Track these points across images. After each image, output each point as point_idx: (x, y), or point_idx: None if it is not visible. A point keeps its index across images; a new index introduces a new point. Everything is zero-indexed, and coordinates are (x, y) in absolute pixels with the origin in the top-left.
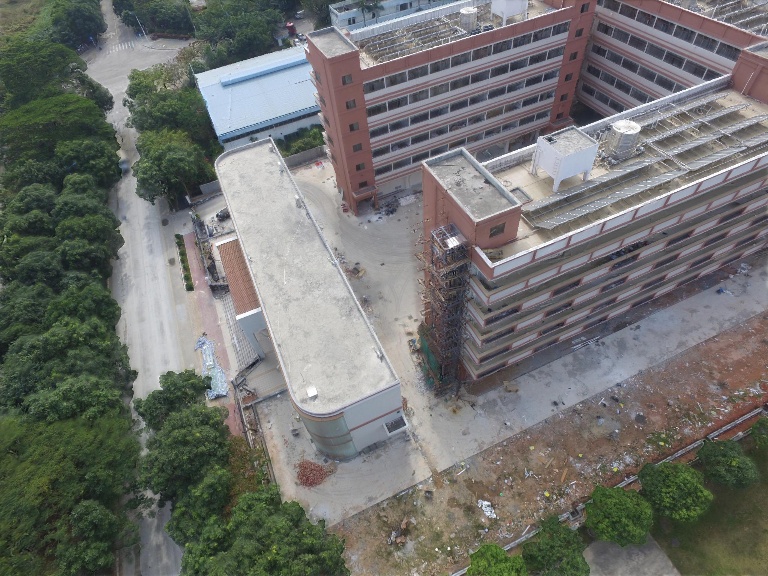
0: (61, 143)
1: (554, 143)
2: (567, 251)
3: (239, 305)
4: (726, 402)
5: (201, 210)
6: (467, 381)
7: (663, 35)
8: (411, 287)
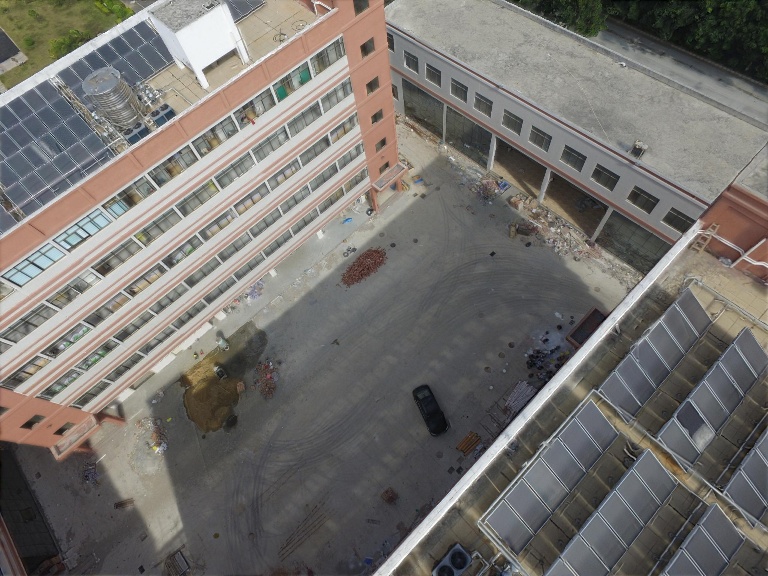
0: None
1: (206, 3)
2: None
3: None
4: None
5: None
6: None
7: None
8: (438, 232)
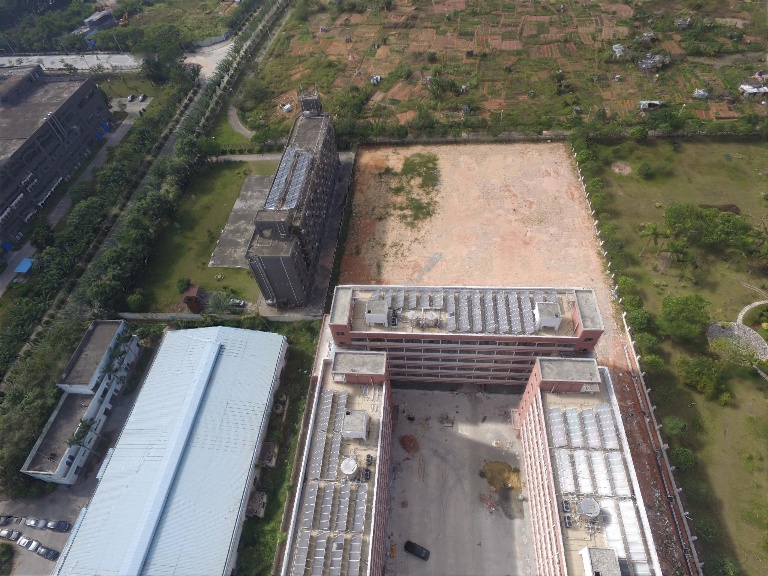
0: None
1: (602, 575)
2: None
3: None
4: (662, 516)
5: None
6: None
7: (433, 345)
8: None
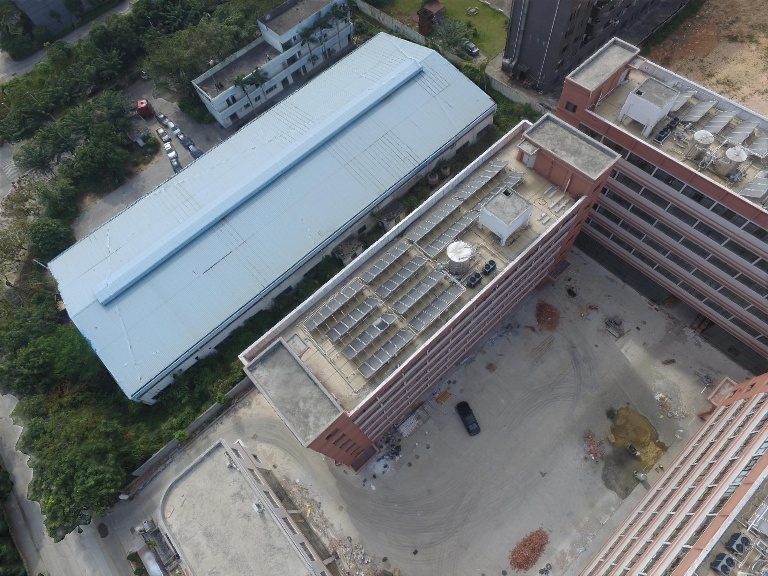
0: None
1: None
2: None
3: None
4: None
5: (146, 500)
6: None
7: (695, 205)
8: None
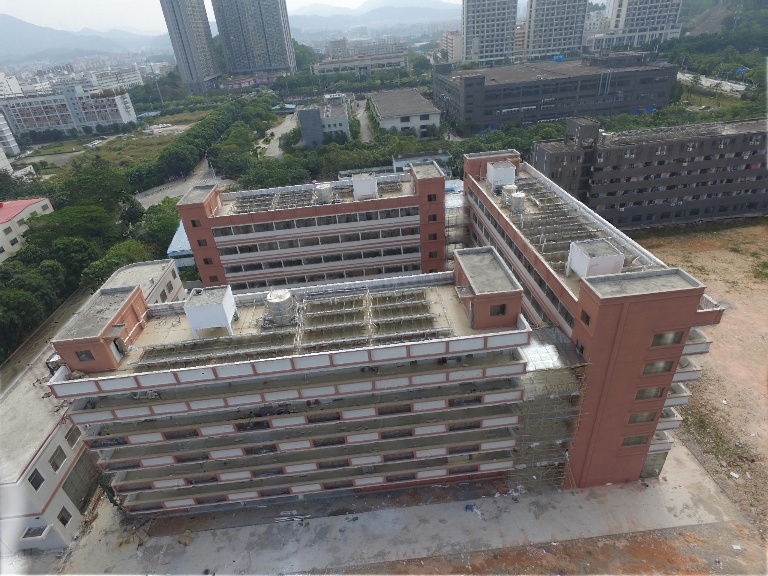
0: (62, 237)
1: (197, 295)
2: (161, 394)
3: None
4: None
5: None
6: (157, 517)
7: (494, 231)
8: None
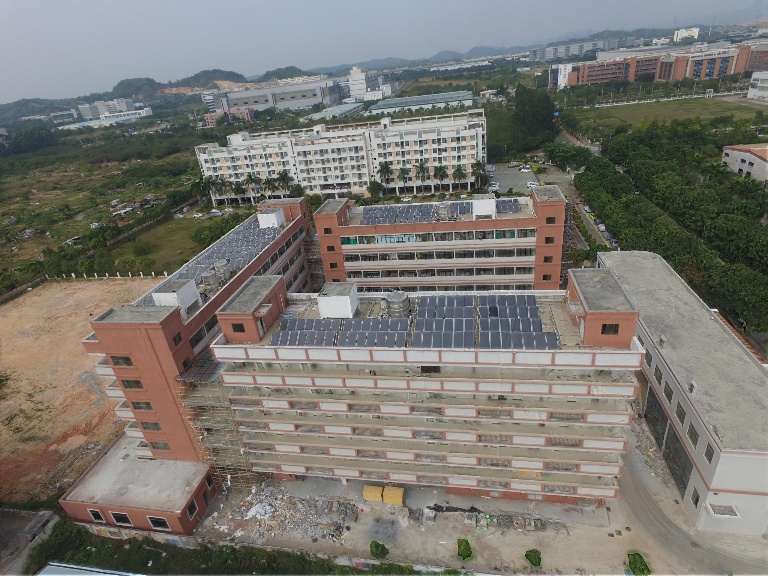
0: None
1: None
2: None
3: (718, 316)
4: None
5: None
6: None
7: None
8: None
